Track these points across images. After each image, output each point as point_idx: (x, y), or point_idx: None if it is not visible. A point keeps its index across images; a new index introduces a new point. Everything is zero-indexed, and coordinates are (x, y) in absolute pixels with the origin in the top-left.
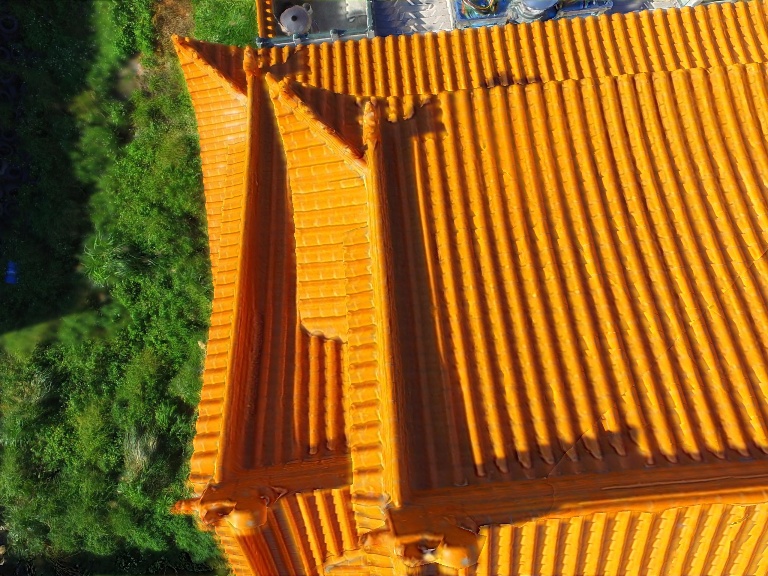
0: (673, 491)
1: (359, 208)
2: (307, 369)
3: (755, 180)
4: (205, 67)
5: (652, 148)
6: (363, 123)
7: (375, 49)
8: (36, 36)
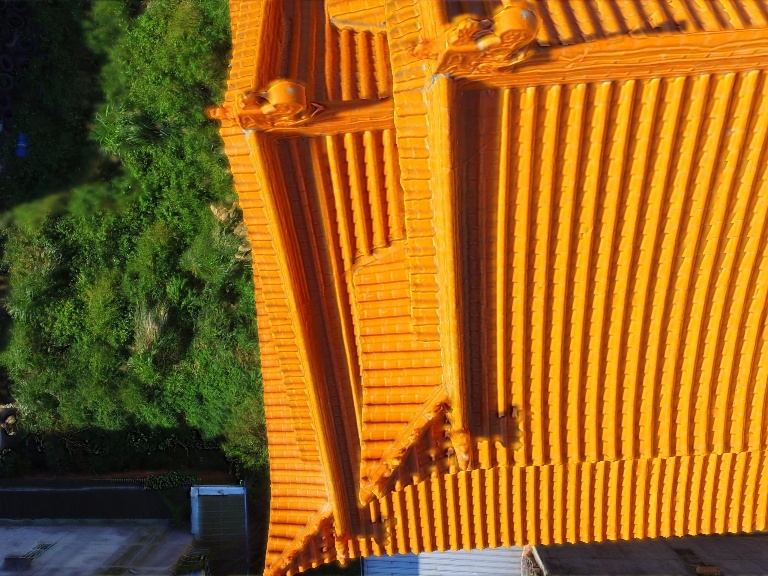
0: (730, 30)
1: None
2: (338, 54)
3: None
4: None
5: None
6: None
7: None
8: None
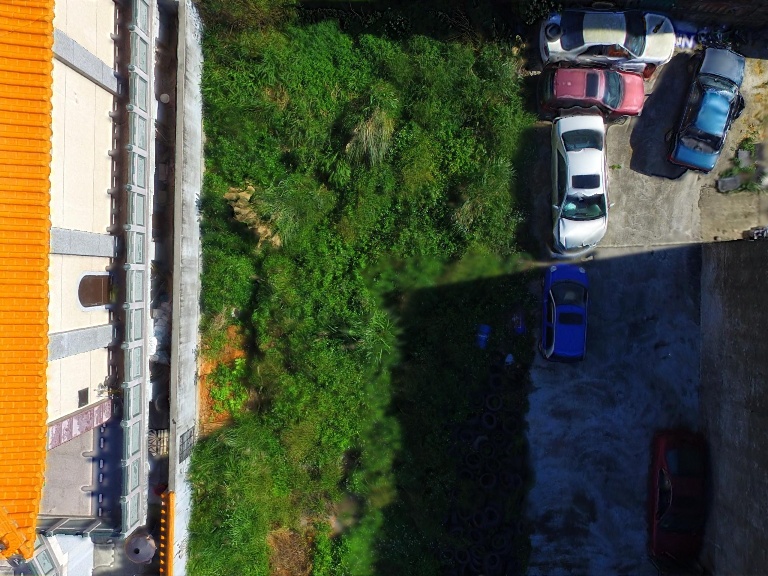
0: None
1: None
2: None
3: None
4: (1, 522)
5: None
6: None
7: None
8: (428, 569)
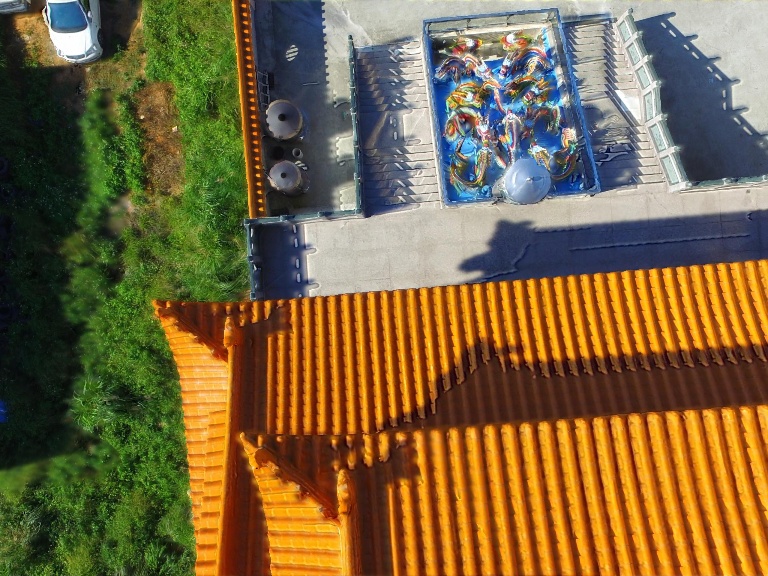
0: None
1: (334, 554)
2: None
3: (728, 551)
4: (186, 333)
5: (626, 504)
6: (337, 488)
7: (357, 307)
8: (26, 175)
